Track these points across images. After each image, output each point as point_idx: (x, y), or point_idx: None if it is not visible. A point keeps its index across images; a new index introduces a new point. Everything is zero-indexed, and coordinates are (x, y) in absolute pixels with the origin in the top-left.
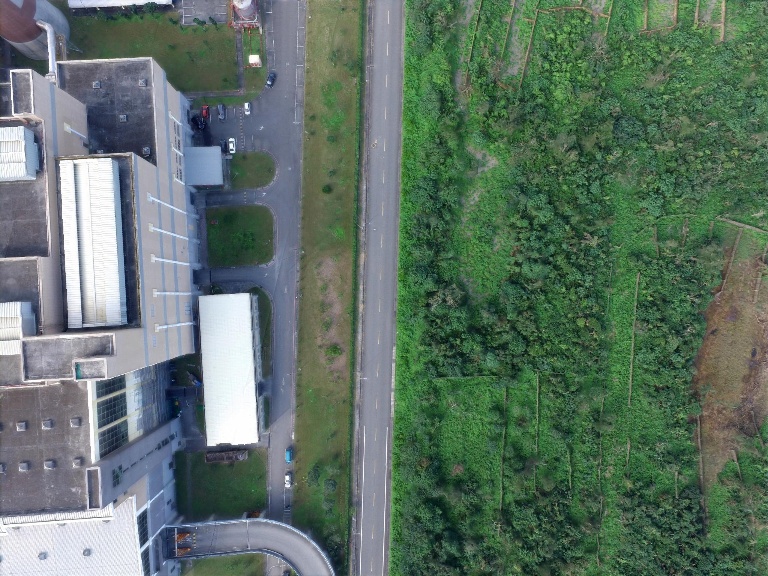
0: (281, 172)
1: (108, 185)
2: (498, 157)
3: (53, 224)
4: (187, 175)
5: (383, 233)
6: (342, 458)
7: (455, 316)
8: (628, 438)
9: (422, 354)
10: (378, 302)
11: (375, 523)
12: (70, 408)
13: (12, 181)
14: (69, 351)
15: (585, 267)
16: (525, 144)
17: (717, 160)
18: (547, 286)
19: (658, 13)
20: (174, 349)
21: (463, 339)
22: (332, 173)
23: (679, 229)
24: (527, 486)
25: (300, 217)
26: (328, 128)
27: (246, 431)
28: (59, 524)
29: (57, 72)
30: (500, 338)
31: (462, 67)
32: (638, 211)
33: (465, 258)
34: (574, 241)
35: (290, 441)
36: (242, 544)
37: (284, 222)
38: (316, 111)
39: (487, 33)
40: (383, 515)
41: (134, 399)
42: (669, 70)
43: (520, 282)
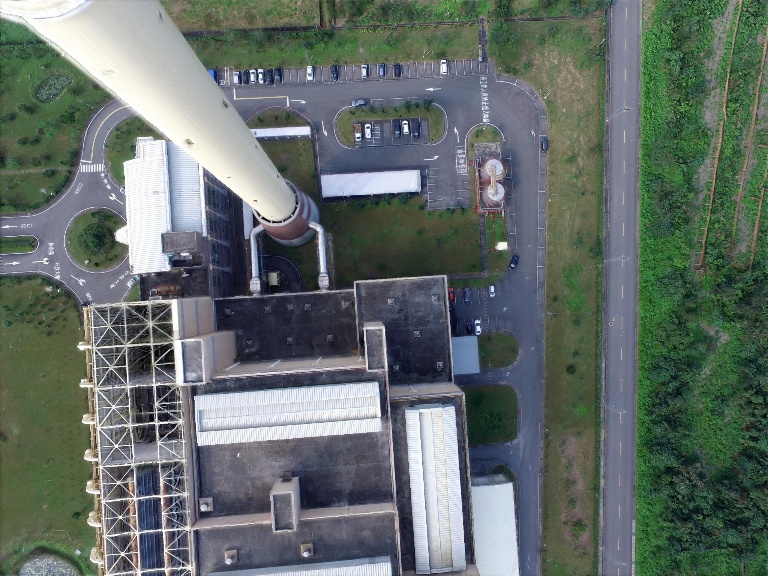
0: (524, 352)
1: (452, 433)
2: (730, 333)
3: (394, 468)
4: None
5: (622, 409)
6: None
7: (701, 496)
8: None
9: (664, 529)
10: (618, 477)
11: None
12: None
13: None
14: None
15: None
16: (761, 324)
17: None
18: None
19: None
20: None
21: (705, 515)
22: (577, 355)
23: None
24: None
25: (543, 396)
26: (570, 309)
27: None
28: None
29: None
30: (740, 513)
31: (696, 247)
32: None
33: (698, 431)
34: None
35: None
36: None
37: (528, 401)
38: (558, 292)
39: None
40: None
41: None
42: None
43: (754, 456)
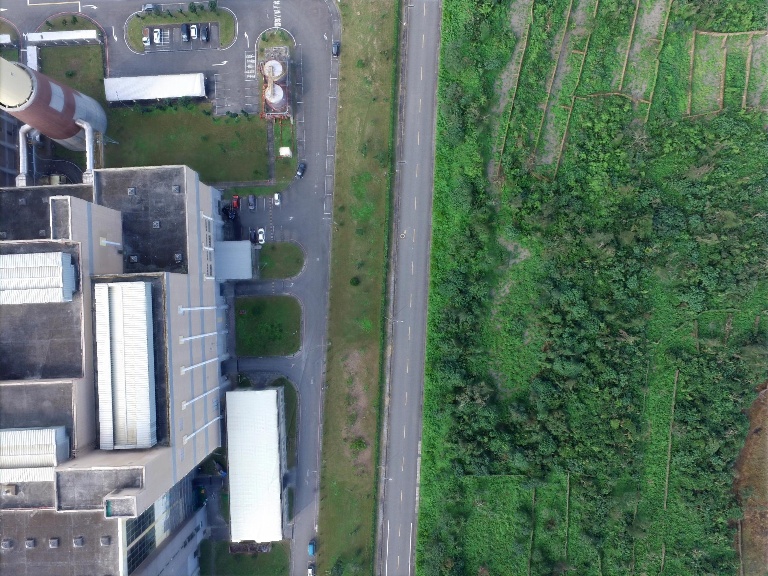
0: (309, 262)
1: (141, 308)
2: (530, 249)
3: (87, 344)
4: (217, 269)
5: (411, 325)
6: (365, 553)
7: (483, 415)
8: (663, 543)
9: (448, 451)
10: (404, 395)
11: None
12: (100, 526)
13: None
14: (100, 482)
15: (620, 365)
16: (559, 238)
17: (764, 253)
18: (580, 384)
19: (703, 96)
20: (201, 452)
21: (491, 438)
22: (360, 266)
23: (722, 326)
24: None
25: (327, 308)
26: (357, 219)
27: (270, 529)
28: None
29: (94, 180)
30: (529, 438)
31: (495, 157)
32: (678, 305)
33: (494, 351)
34: (609, 340)
35: (313, 533)
36: None
37: (311, 313)
38: (345, 202)
39: (521, 122)
40: None
41: (162, 502)
42: (714, 160)
43: (551, 379)
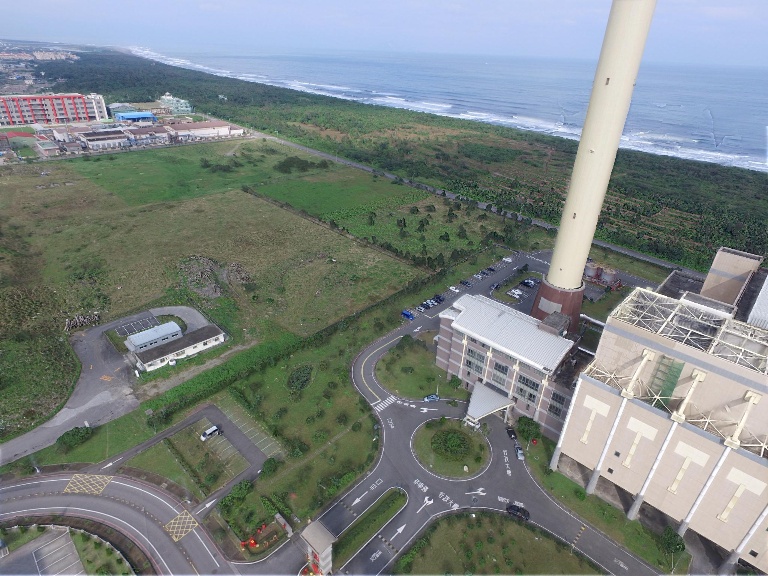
0: None
1: None
2: None
3: None
4: None
5: None
6: None
7: None
8: None
9: None
10: None
11: None
12: None
13: None
14: None
15: None
16: None
17: None
18: None
19: None
20: None
21: None
22: None
23: None
24: None
25: None
26: None
27: None
28: None
29: None
30: None
31: None
32: None
33: None
34: None
35: None
36: None
37: None
38: None
39: None
40: None
41: None
42: None
43: None
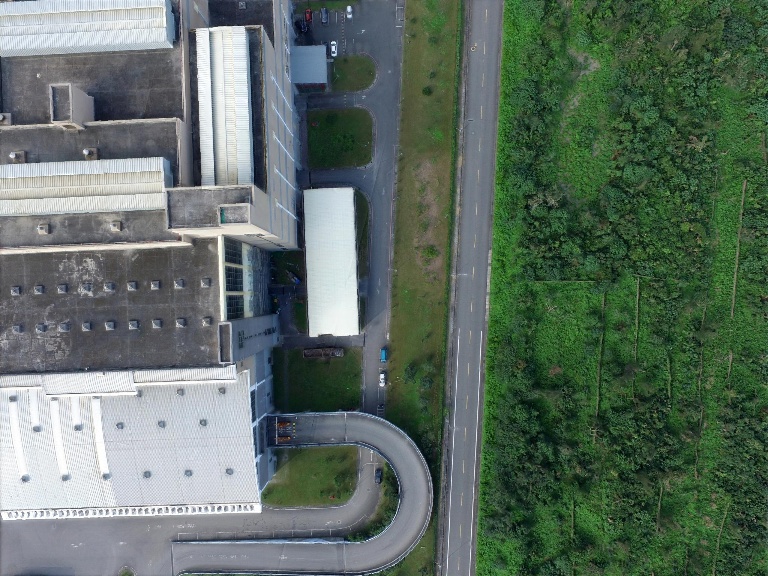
0: (381, 75)
1: (241, 52)
2: (600, 60)
3: (187, 92)
4: (293, 73)
5: (481, 136)
6: (436, 359)
7: (556, 217)
8: (730, 350)
9: (519, 257)
10: (475, 205)
11: (468, 425)
12: (200, 269)
13: (149, 51)
14: (210, 202)
15: (690, 172)
16: (630, 44)
17: None
18: (650, 190)
19: None
20: (286, 233)
21: (562, 242)
22: (433, 74)
23: None
24: (624, 393)
25: (399, 120)
26: (429, 31)
27: (347, 323)
28: (179, 393)
29: None
30: (600, 241)
31: None
32: (745, 117)
33: (564, 163)
34: (680, 143)
35: (385, 341)
36: (340, 436)
37: (383, 125)
38: (417, 14)
39: None
40: (476, 418)
41: (248, 279)
42: None
43: (621, 187)
